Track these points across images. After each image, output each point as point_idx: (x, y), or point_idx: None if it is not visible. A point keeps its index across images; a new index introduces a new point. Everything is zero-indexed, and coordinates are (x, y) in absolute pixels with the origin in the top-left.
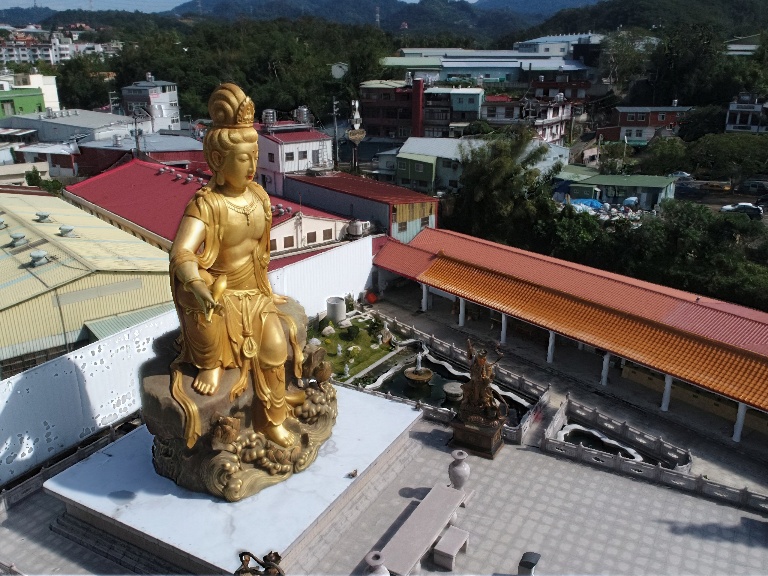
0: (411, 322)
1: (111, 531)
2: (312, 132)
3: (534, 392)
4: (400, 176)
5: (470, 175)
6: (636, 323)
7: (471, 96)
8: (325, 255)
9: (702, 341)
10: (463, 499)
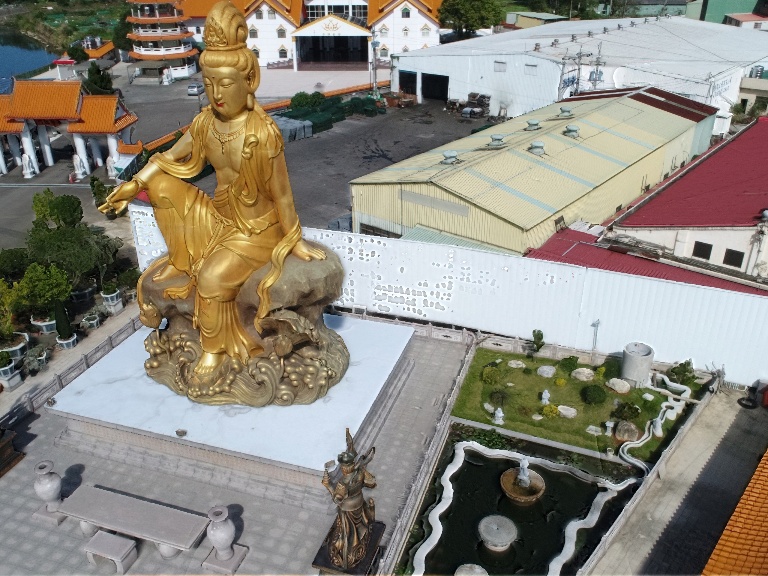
0: (728, 458)
1: None
2: None
3: None
4: None
5: None
6: None
7: None
8: (683, 287)
9: None
10: (179, 547)
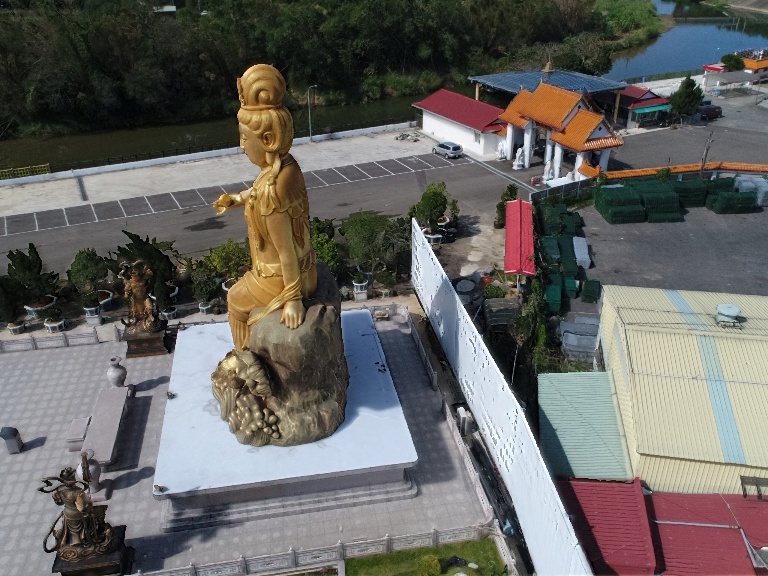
0: None
1: None
2: None
3: None
4: None
5: None
6: None
7: None
8: None
9: None
10: None
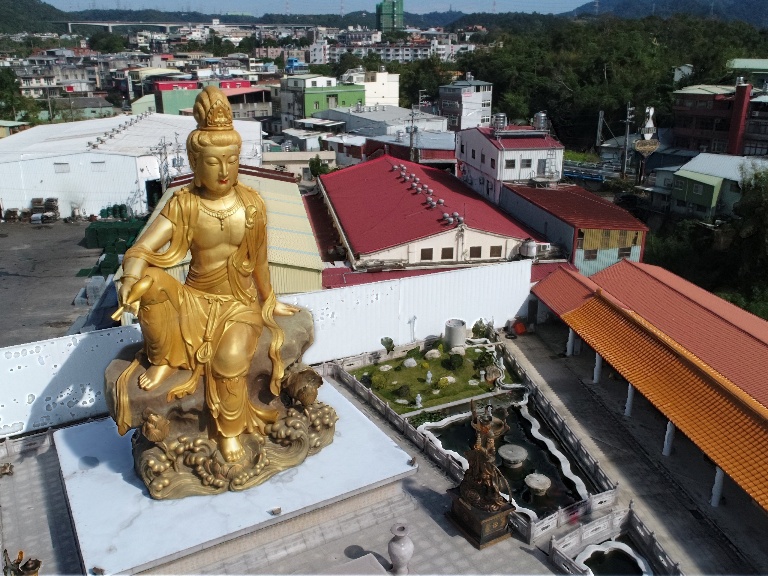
0: (541, 365)
1: None
2: (547, 139)
3: (605, 486)
4: (675, 197)
5: (745, 204)
6: None
7: None
8: (460, 273)
9: None
10: None
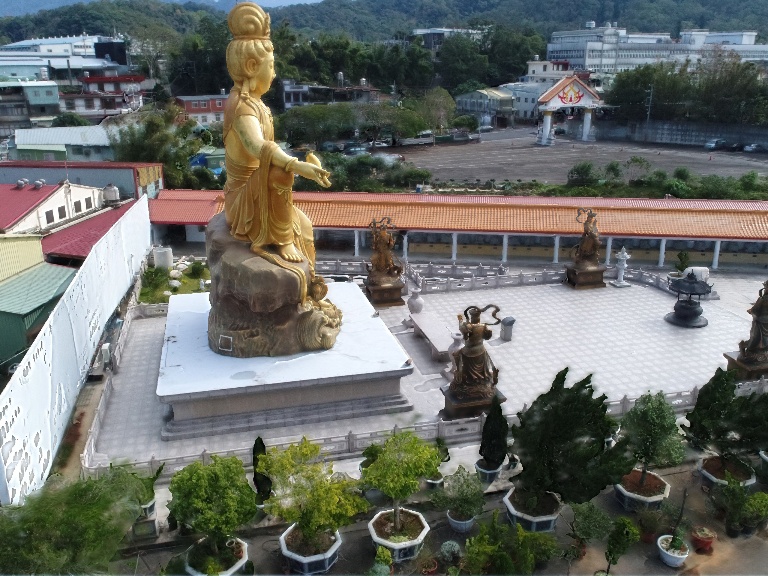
0: None
1: (240, 410)
2: None
3: None
4: None
5: (126, 154)
6: (418, 207)
7: (48, 88)
8: (133, 210)
9: (466, 206)
10: None
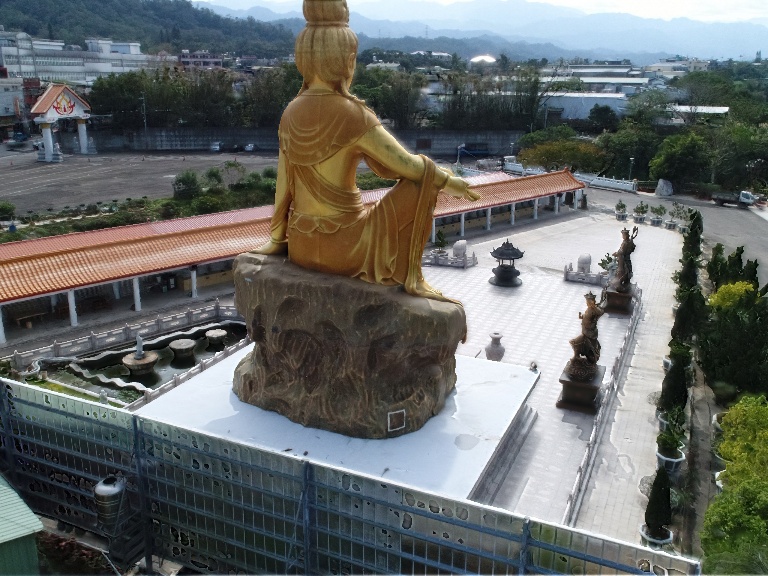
0: None
1: None
2: None
3: (204, 317)
4: None
5: None
6: (194, 235)
7: None
8: None
9: (241, 225)
10: None
